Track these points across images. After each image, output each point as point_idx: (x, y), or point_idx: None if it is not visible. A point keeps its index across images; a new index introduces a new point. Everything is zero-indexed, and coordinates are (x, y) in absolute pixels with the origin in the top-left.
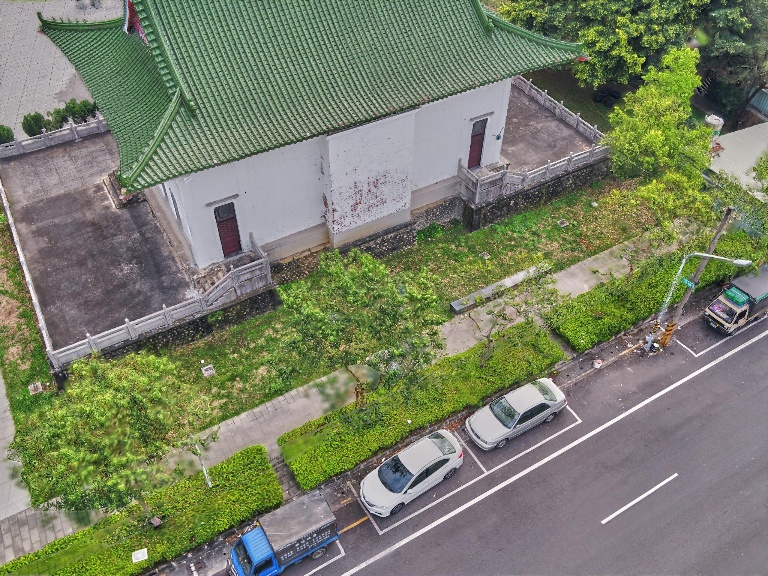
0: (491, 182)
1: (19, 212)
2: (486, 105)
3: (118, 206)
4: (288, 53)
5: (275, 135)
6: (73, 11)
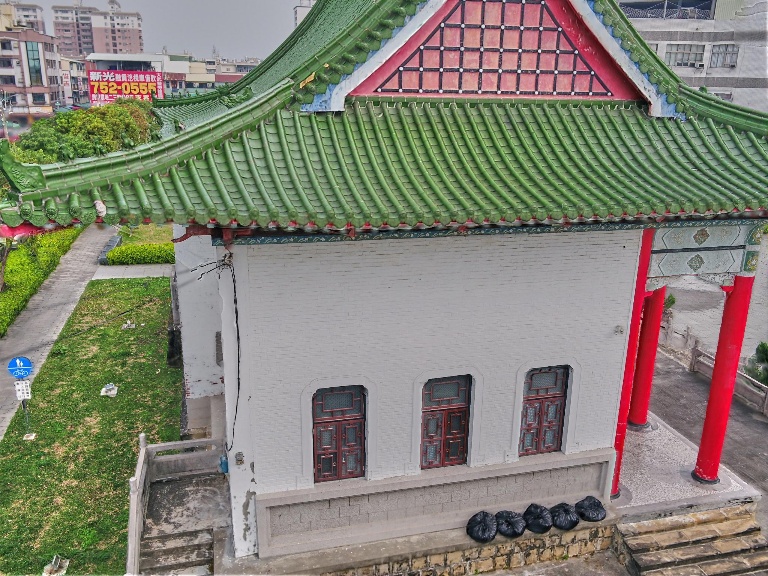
0: None
1: None
2: None
3: None
4: None
5: None
6: None
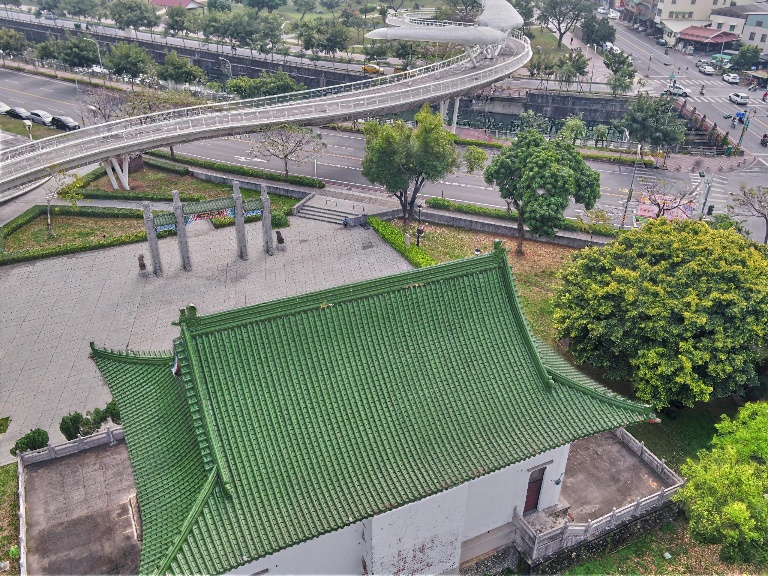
0: (550, 537)
1: (35, 539)
2: (545, 455)
3: (140, 537)
4: (336, 418)
5: (314, 520)
6: (135, 279)
